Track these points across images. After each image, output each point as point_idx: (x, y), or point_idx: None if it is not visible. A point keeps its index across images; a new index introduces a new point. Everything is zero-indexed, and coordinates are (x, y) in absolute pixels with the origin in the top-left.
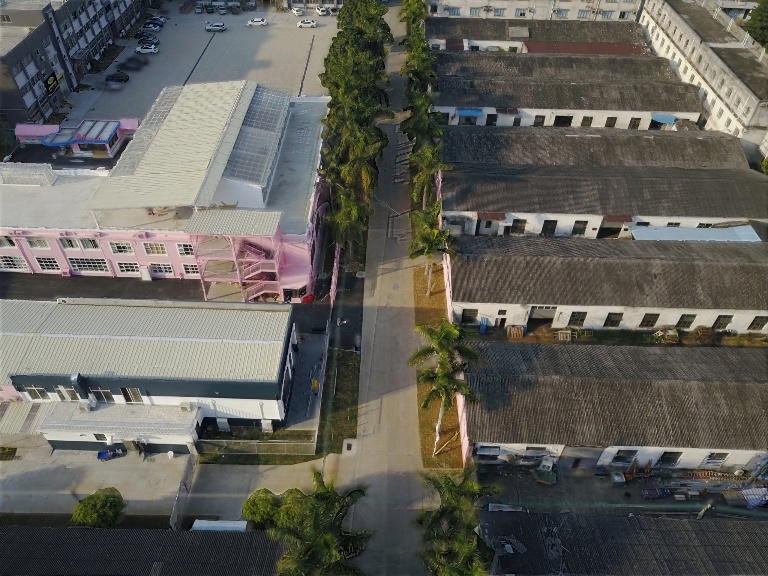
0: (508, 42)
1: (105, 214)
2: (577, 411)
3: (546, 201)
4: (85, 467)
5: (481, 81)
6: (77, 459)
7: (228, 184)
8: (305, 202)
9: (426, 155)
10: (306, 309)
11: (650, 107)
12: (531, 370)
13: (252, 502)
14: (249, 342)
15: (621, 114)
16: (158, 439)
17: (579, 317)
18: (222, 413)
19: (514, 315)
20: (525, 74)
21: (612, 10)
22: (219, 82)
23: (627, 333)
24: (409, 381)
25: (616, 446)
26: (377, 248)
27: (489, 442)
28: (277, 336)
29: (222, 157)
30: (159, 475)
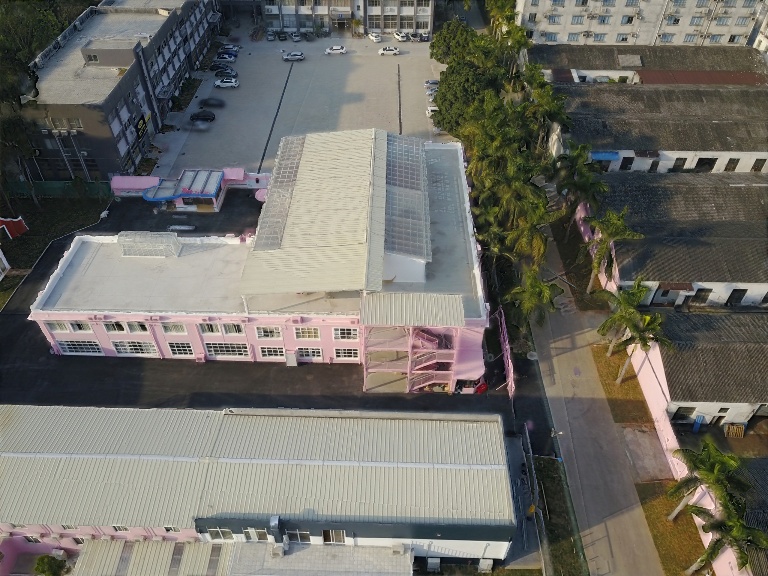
0: (619, 71)
1: None
2: None
3: (736, 268)
4: None
5: (614, 120)
6: None
7: (390, 259)
8: (468, 274)
9: (612, 222)
10: (481, 401)
11: None
12: None
13: None
14: (466, 467)
15: None
16: None
17: None
18: (435, 552)
19: (736, 413)
20: (652, 109)
21: (722, 34)
22: (344, 131)
23: None
24: (630, 498)
25: None
26: None
27: None
28: (496, 458)
29: (377, 226)
30: None
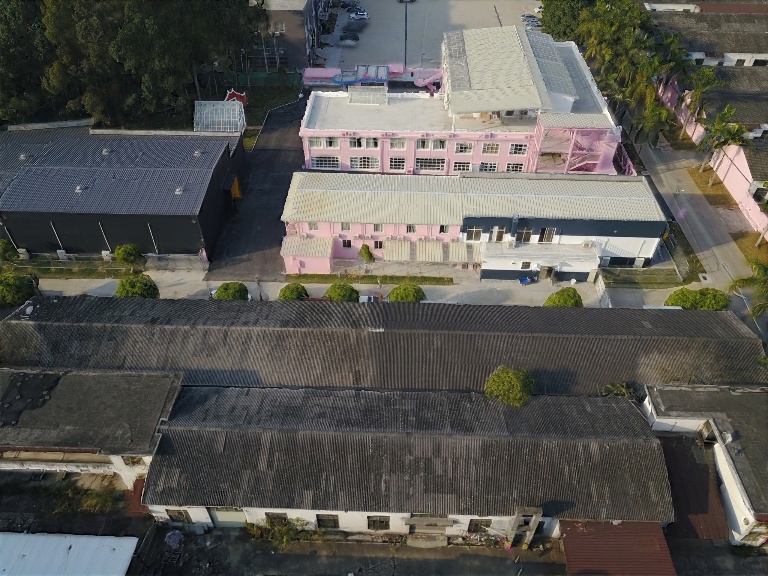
0: (683, 5)
1: (446, 123)
2: None
3: None
4: (511, 289)
5: (688, 31)
6: (502, 285)
7: (550, 97)
8: None
9: (706, 73)
10: None
11: None
12: None
13: (682, 294)
14: (627, 198)
15: None
16: (569, 267)
17: None
18: (607, 252)
19: None
20: (715, 28)
21: None
22: None
23: None
24: (727, 239)
25: None
26: (648, 155)
27: None
28: (646, 195)
29: (538, 77)
30: None
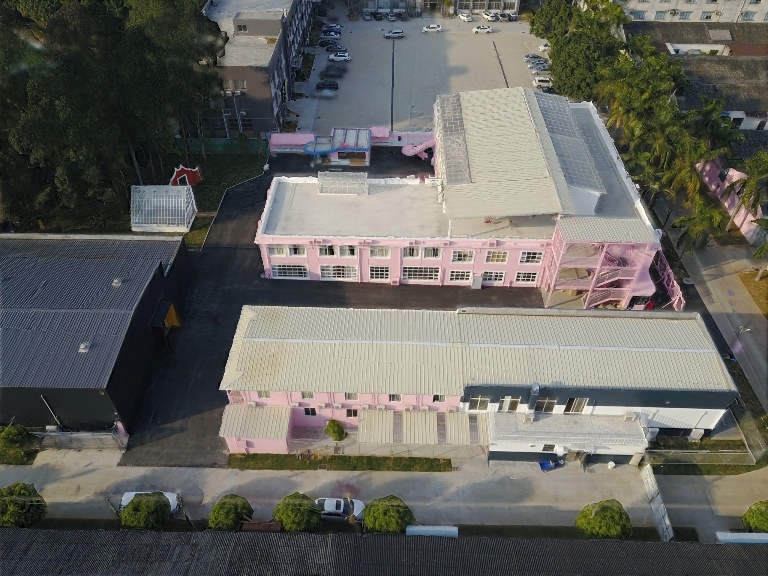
0: (710, 45)
1: (440, 222)
2: None
3: None
4: (529, 478)
5: (724, 85)
6: (517, 470)
7: (570, 191)
8: (631, 208)
9: (764, 160)
10: None
11: None
12: None
13: None
14: (681, 351)
15: None
16: (607, 449)
17: None
18: (655, 423)
19: None
20: (751, 77)
21: None
22: None
23: None
24: None
25: None
26: None
27: None
28: (704, 345)
29: (554, 164)
30: (608, 486)
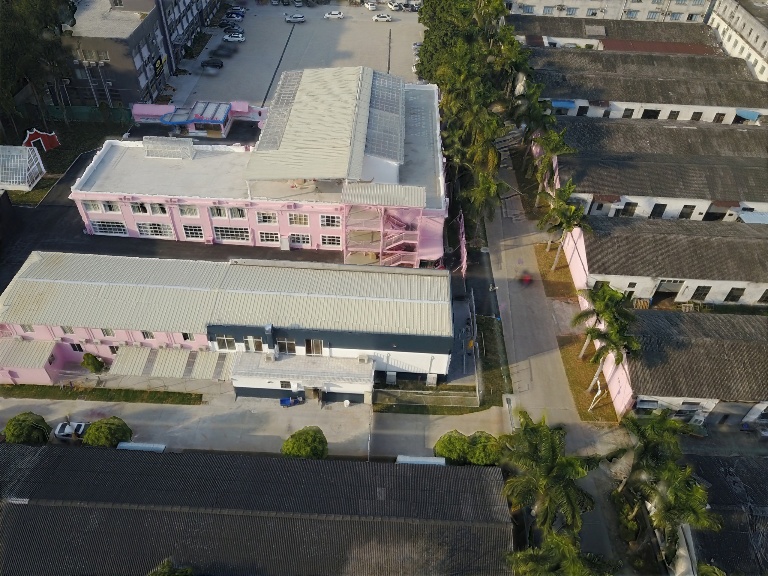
0: (585, 40)
1: None
2: (730, 370)
3: (658, 186)
4: (269, 412)
5: (573, 75)
6: (260, 405)
7: (369, 160)
8: (434, 180)
9: (553, 138)
10: None
11: (735, 103)
12: (682, 333)
13: (448, 441)
14: (418, 302)
15: (707, 109)
16: (339, 388)
17: (703, 291)
18: (392, 367)
19: (643, 288)
20: (609, 70)
21: (681, 12)
22: None
23: (746, 308)
24: (551, 345)
25: (766, 402)
26: (495, 226)
27: (651, 395)
28: (443, 297)
29: (360, 135)
30: (339, 421)
